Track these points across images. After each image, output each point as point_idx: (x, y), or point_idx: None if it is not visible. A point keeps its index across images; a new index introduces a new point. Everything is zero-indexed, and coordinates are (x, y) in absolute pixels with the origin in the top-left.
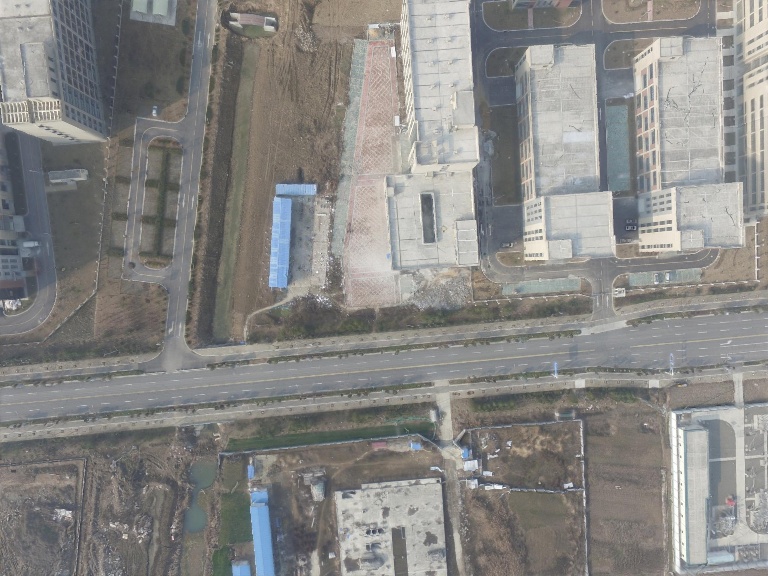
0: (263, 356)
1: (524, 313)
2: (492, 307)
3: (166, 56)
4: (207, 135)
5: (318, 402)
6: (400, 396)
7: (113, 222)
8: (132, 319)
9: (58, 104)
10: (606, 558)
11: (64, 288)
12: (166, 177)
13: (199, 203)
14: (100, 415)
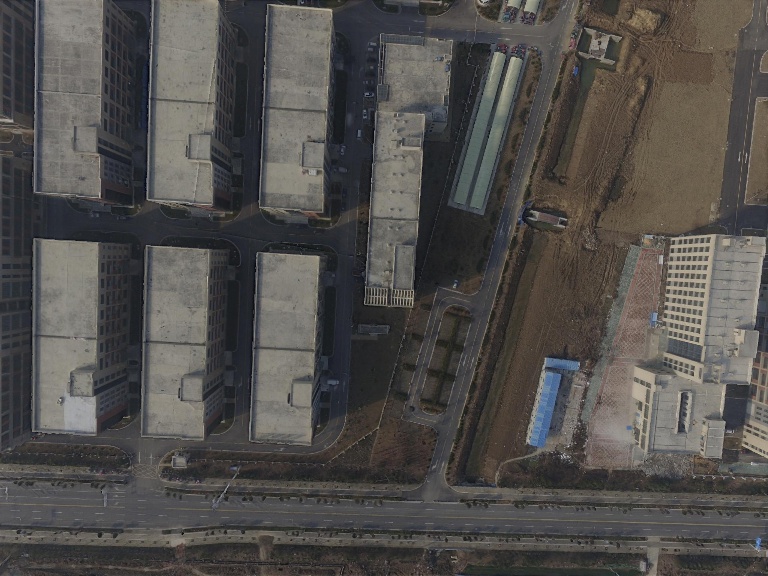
0: (508, 498)
1: (733, 489)
2: (707, 481)
3: (472, 240)
4: (495, 309)
5: (548, 542)
6: None
7: (403, 371)
8: (404, 454)
9: (412, 293)
10: None
11: (351, 421)
12: (454, 340)
13: (478, 364)
14: (363, 531)
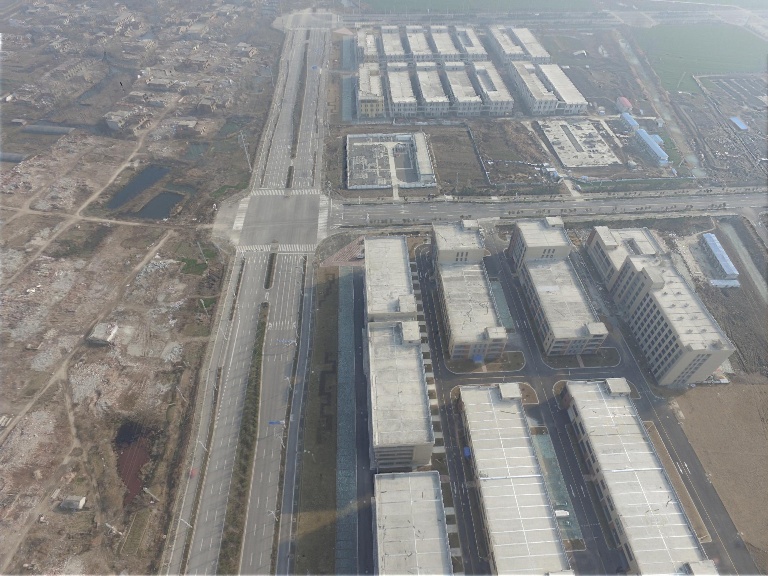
0: (695, 212)
1: None
2: None
3: None
4: None
5: (651, 194)
6: (603, 196)
7: None
8: None
9: None
10: (462, 141)
11: None
12: None
13: None
14: None
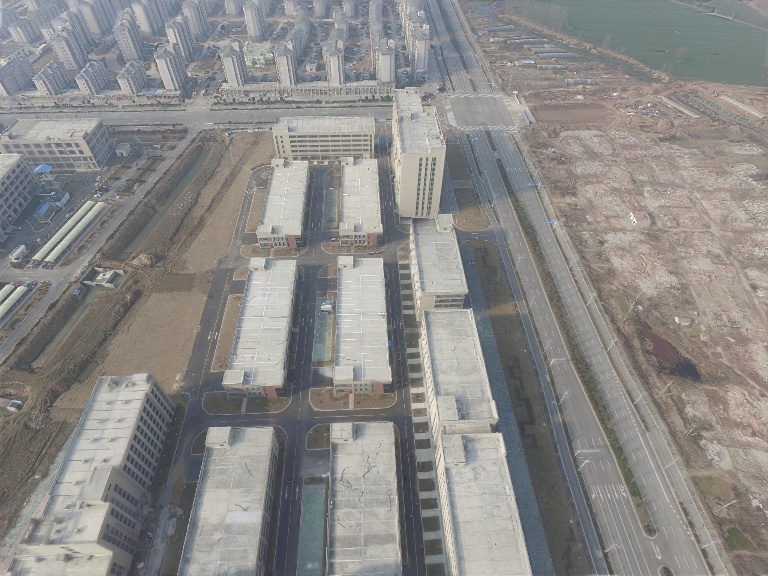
0: None
1: None
2: None
3: None
4: None
5: None
6: None
7: None
8: None
9: None
10: None
11: None
12: None
13: None
14: None
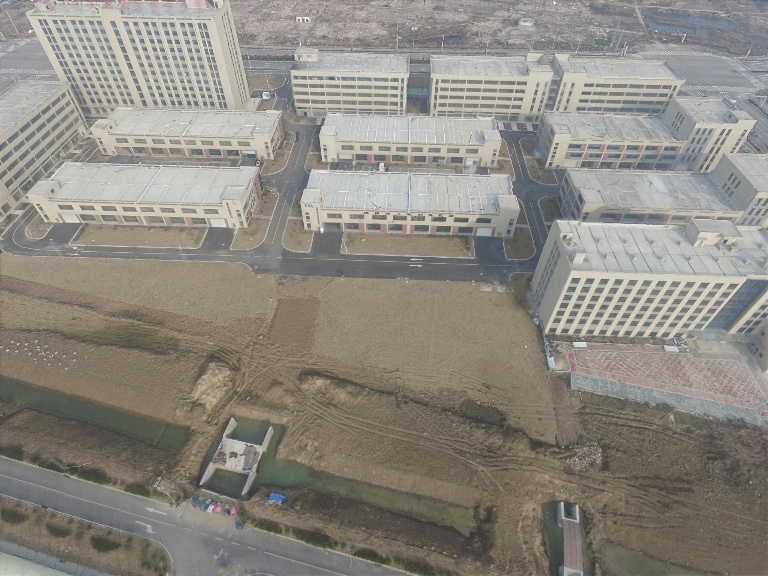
0: None
1: None
2: None
3: None
4: None
5: None
6: None
7: None
8: None
9: None
10: None
11: None
12: None
13: None
14: None
